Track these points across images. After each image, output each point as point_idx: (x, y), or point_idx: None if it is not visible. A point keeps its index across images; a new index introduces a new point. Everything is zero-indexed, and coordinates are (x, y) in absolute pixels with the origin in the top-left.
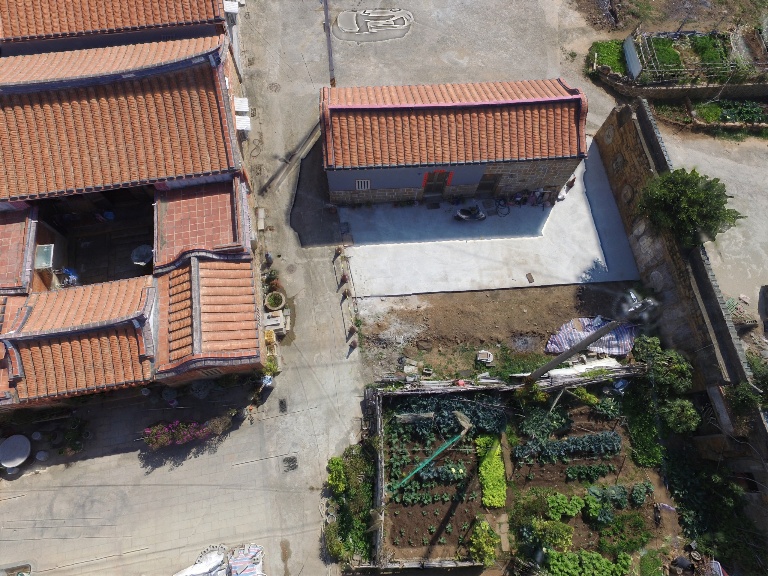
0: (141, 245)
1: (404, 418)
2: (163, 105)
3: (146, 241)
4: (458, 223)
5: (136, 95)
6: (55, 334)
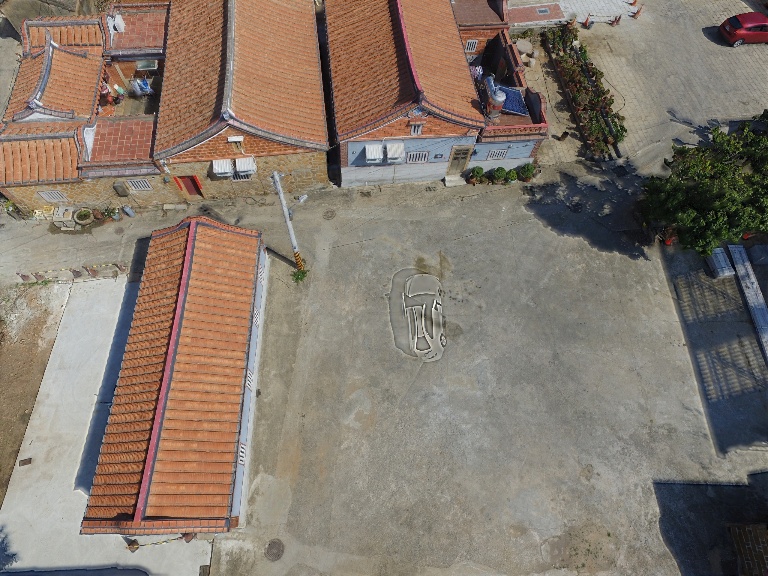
0: None
1: None
2: None
3: None
4: None
5: None
6: None
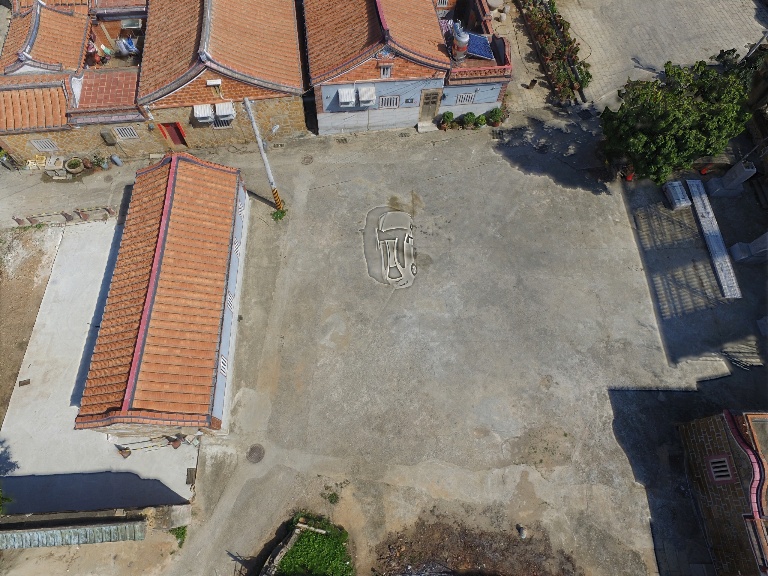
0: None
1: None
2: None
3: None
4: None
5: None
6: None
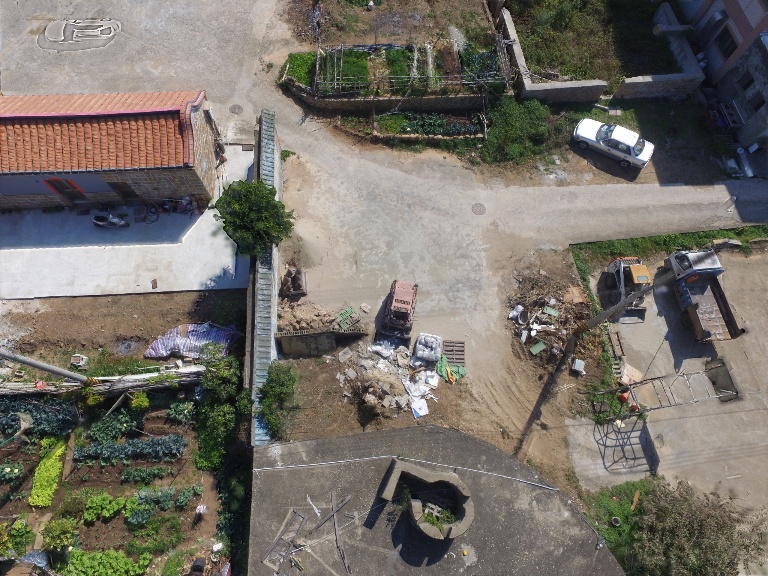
0: None
1: None
2: None
3: None
4: (102, 229)
5: None
6: None
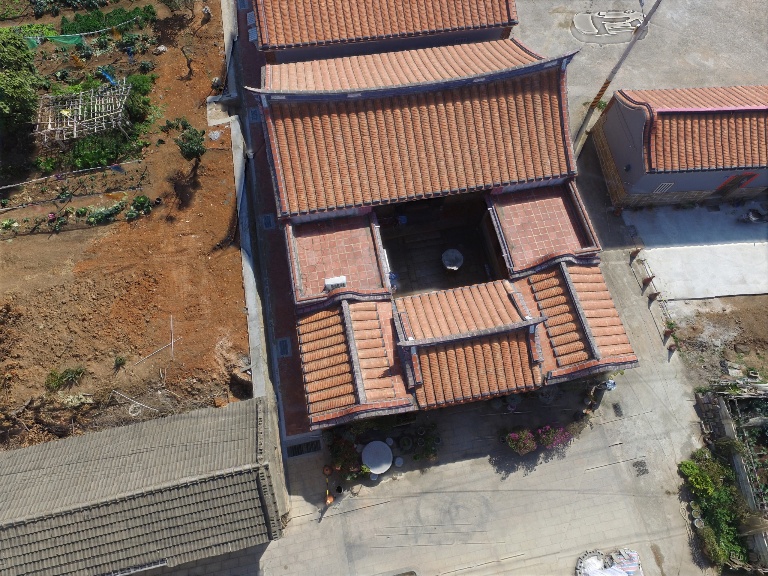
0: (448, 249)
1: (754, 422)
2: (506, 109)
3: (439, 245)
4: (743, 225)
5: (481, 99)
6: (455, 340)
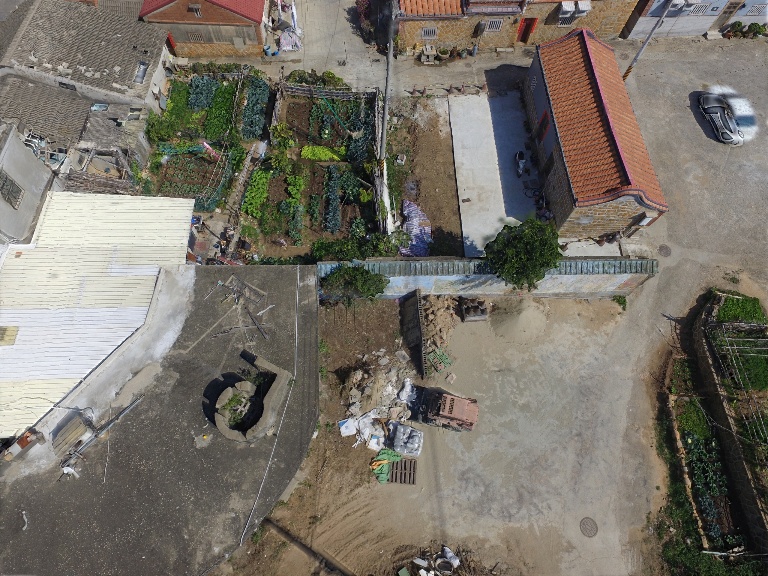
0: None
1: None
2: None
3: None
4: (513, 160)
5: None
6: None
